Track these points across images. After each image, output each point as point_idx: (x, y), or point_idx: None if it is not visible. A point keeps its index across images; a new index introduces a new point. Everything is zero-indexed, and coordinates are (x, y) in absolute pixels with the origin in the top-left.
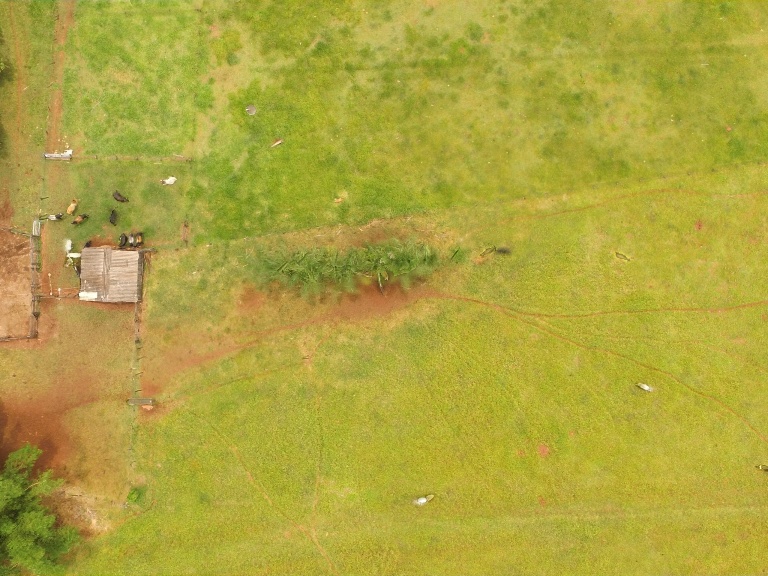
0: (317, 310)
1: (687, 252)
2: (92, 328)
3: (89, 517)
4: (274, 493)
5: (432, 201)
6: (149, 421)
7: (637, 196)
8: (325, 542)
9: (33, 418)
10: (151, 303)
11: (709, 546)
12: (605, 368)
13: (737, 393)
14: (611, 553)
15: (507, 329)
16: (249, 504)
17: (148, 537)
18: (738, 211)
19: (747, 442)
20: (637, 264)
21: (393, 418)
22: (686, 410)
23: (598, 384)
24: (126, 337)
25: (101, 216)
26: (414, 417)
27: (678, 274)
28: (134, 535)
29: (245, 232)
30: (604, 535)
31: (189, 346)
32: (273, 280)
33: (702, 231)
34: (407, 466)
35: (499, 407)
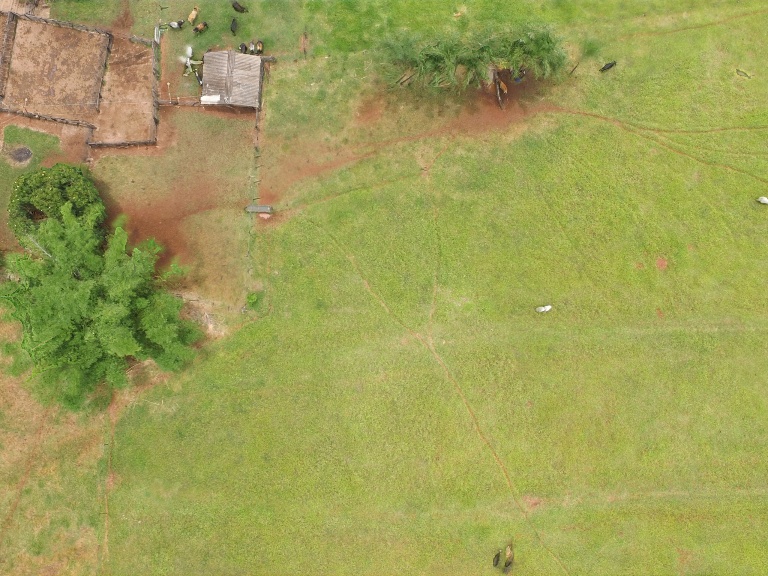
0: (435, 122)
1: None
2: (211, 136)
3: (206, 322)
4: (391, 300)
5: (551, 17)
6: (266, 229)
7: (758, 14)
8: (442, 350)
9: (151, 224)
10: (270, 113)
11: None
12: (725, 183)
13: None
14: (730, 366)
15: (626, 144)
16: (366, 312)
17: (265, 342)
18: None
19: None
20: (758, 81)
21: (511, 229)
22: None
23: (718, 199)
24: (244, 146)
25: (221, 26)
26: (532, 228)
27: None
28: (251, 340)
29: (364, 44)
30: (723, 348)
31: (307, 156)
32: (391, 92)
33: None
34: (525, 277)
35: (618, 219)
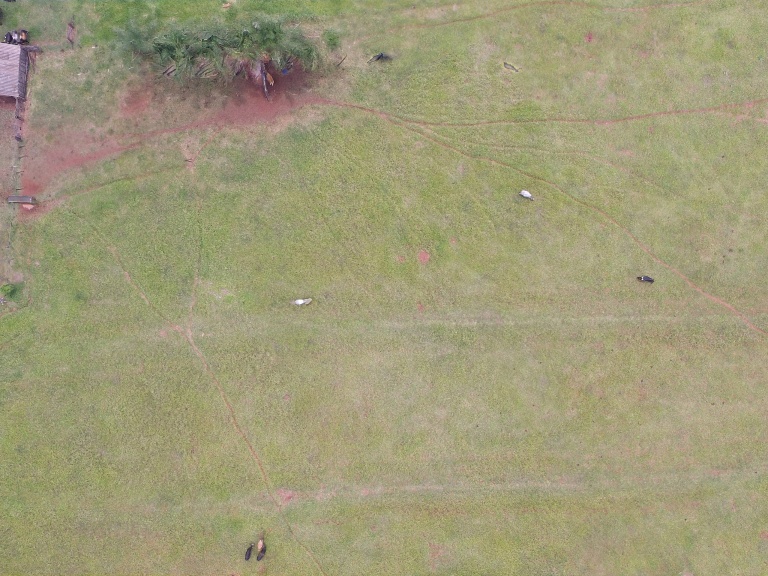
0: (201, 114)
1: (576, 64)
2: None
3: None
4: (151, 292)
5: (321, 8)
6: (29, 219)
7: (527, 7)
8: (201, 342)
9: None
10: (34, 102)
11: (587, 355)
12: (489, 177)
13: (621, 204)
14: (488, 360)
15: (392, 136)
16: (126, 303)
17: (23, 334)
18: (629, 24)
19: (630, 253)
20: (525, 74)
21: (273, 221)
22: (569, 220)
23: (481, 192)
24: (8, 136)
25: None
26: (295, 221)
27: (566, 85)
28: (9, 331)
29: (131, 35)
30: (482, 342)
31: (71, 146)
32: (158, 83)
33: (592, 43)
34: (286, 269)
35: (380, 212)
